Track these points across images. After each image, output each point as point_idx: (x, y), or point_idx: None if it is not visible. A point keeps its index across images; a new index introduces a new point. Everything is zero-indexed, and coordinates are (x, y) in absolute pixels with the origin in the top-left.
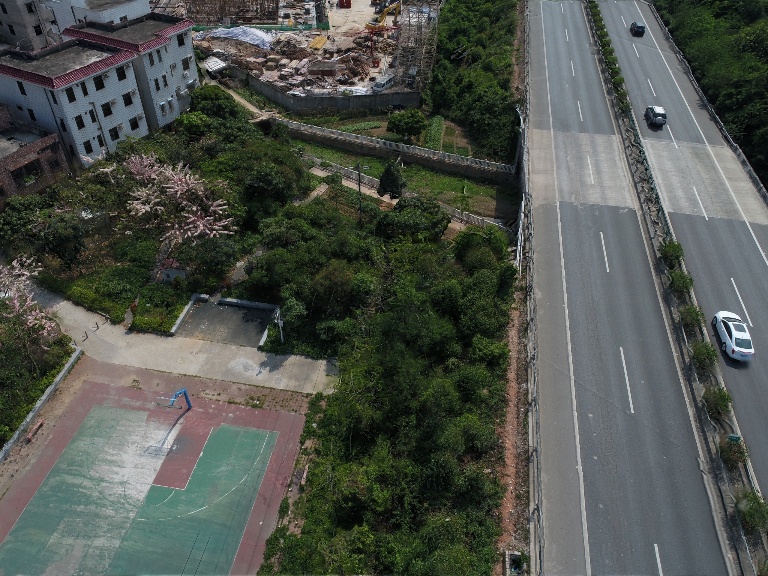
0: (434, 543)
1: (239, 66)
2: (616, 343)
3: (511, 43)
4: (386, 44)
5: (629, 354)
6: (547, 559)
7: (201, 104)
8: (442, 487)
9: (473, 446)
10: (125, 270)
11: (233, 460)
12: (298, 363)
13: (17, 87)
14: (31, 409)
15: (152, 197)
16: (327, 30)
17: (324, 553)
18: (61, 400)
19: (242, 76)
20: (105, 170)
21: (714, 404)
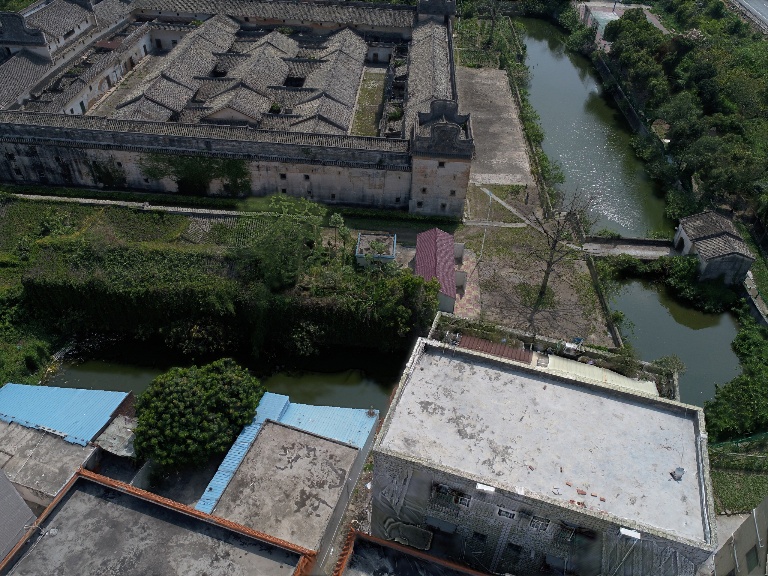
0: (715, 1)
1: None
2: None
3: None
4: None
5: None
6: None
7: None
8: (706, 5)
9: None
10: None
11: None
12: None
13: None
14: None
15: None
16: None
17: (693, 1)
18: None
19: None
20: None
21: None
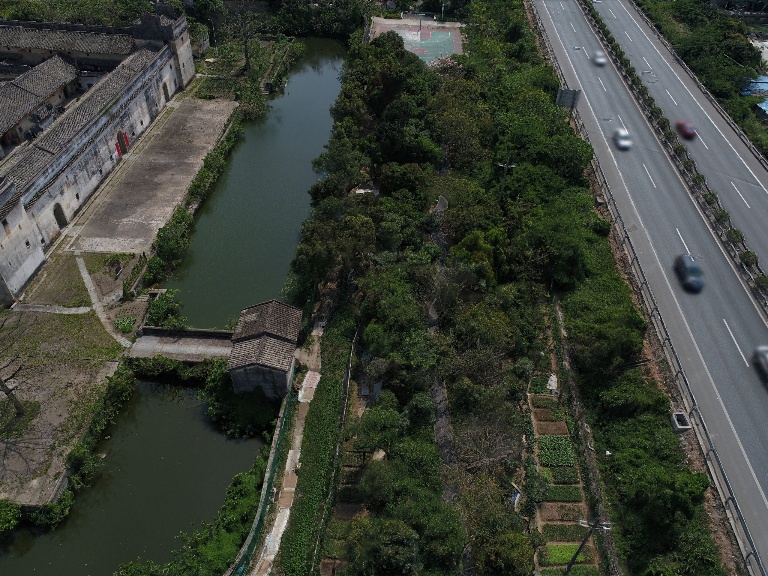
0: None
1: None
2: (558, 1)
3: None
4: None
5: (562, 2)
6: None
7: None
8: None
9: (518, 18)
10: None
11: None
12: None
13: None
14: (370, 28)
15: None
16: None
17: None
18: None
19: None
20: None
21: (587, 4)
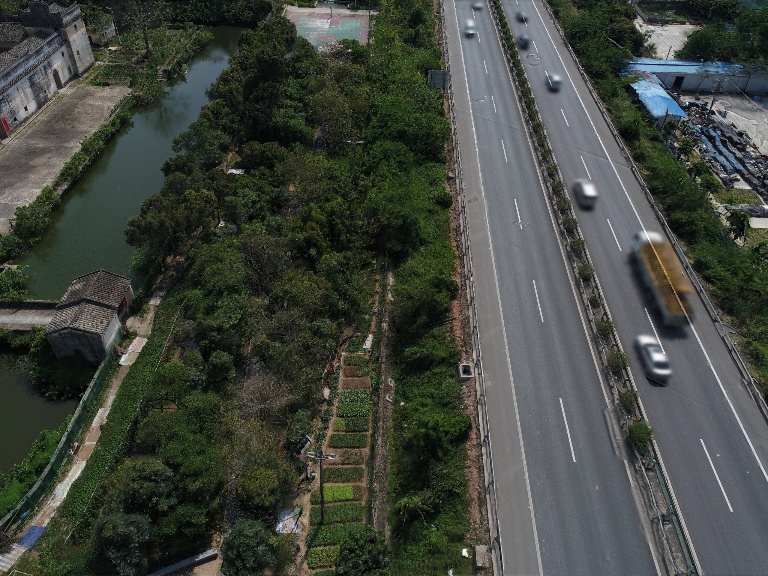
0: None
1: None
2: None
3: None
4: None
5: None
6: (445, 11)
7: None
8: None
9: None
10: None
11: (351, 23)
12: None
13: None
14: None
15: None
16: None
17: (390, 7)
18: (287, 17)
19: None
20: None
21: None
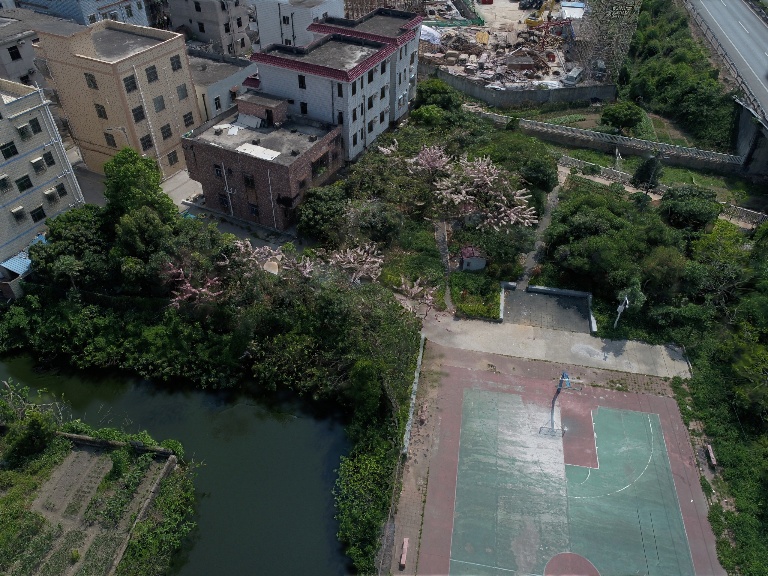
0: None
1: (420, 61)
2: None
3: (690, 36)
4: (553, 38)
5: None
6: None
7: (432, 98)
8: None
9: None
10: (421, 259)
11: (629, 441)
12: (638, 348)
13: (297, 81)
14: None
15: (461, 187)
16: (482, 26)
17: None
18: (429, 383)
19: (431, 71)
20: (408, 161)
21: None
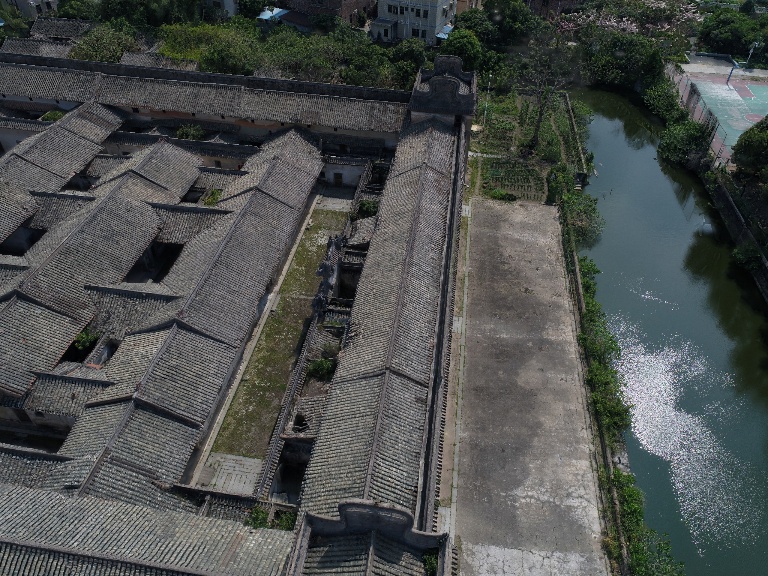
0: None
1: None
2: None
3: None
4: None
5: None
6: None
7: None
8: None
9: None
10: None
11: (766, 92)
12: None
13: None
14: None
15: (661, 1)
16: None
17: None
18: None
19: None
20: None
21: None
